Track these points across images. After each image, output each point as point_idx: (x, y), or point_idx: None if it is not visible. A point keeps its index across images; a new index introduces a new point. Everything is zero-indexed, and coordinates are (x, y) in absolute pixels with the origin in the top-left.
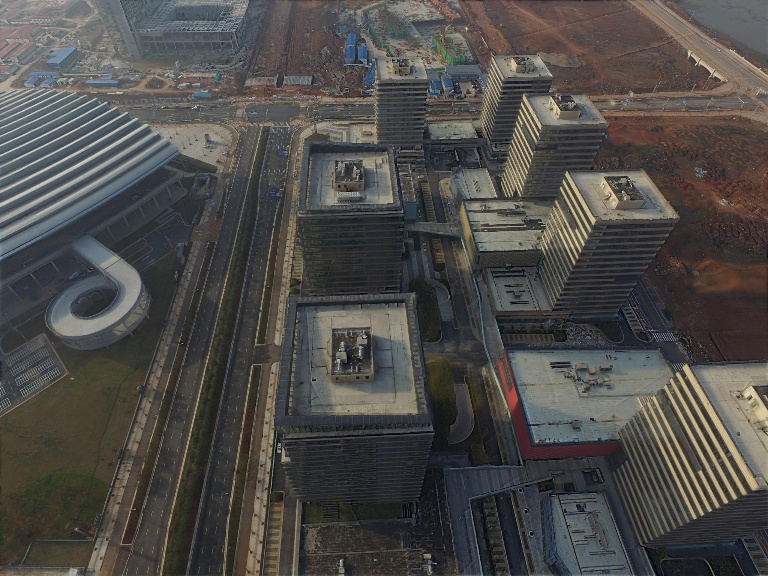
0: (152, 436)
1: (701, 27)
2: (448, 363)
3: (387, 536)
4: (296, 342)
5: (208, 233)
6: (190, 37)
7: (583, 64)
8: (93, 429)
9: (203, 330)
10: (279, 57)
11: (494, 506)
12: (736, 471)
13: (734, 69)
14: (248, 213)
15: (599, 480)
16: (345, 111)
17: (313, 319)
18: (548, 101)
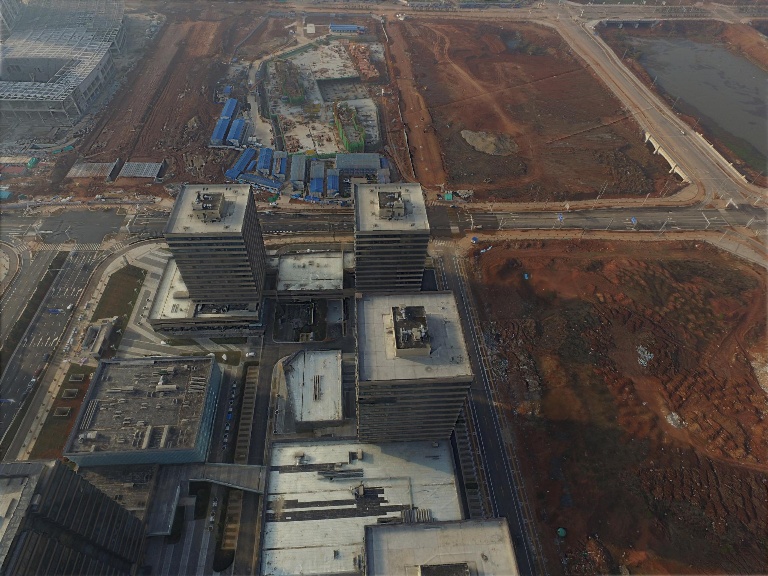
0: None
1: (664, 95)
2: None
3: None
4: None
5: None
6: (8, 104)
7: (515, 150)
8: None
9: None
10: (131, 130)
11: None
12: None
13: (700, 163)
14: None
15: None
16: None
17: None
18: None
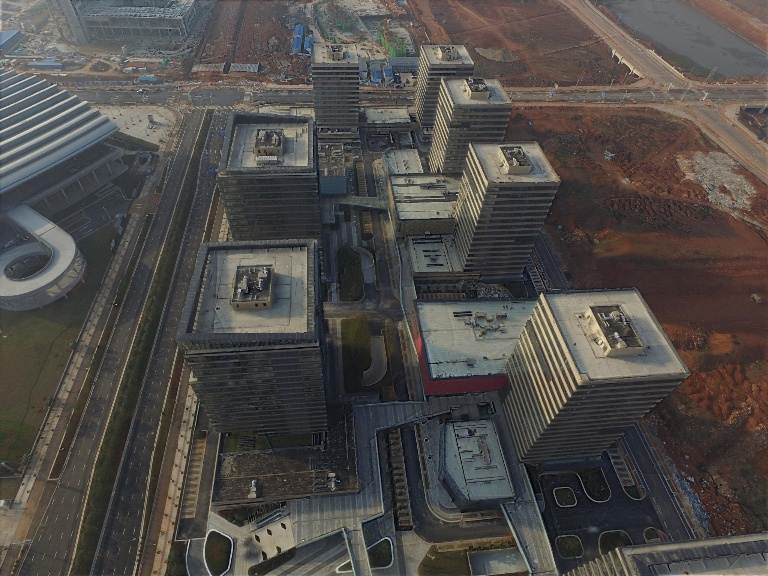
0: (83, 386)
1: (627, 29)
2: (366, 317)
3: (297, 461)
4: (205, 279)
5: (147, 206)
6: (137, 23)
7: (517, 59)
8: (24, 381)
9: (137, 293)
10: (227, 45)
11: (399, 437)
12: (570, 373)
13: (651, 67)
14: (187, 188)
15: (492, 412)
16: (289, 97)
17: (223, 260)
18: (463, 84)
